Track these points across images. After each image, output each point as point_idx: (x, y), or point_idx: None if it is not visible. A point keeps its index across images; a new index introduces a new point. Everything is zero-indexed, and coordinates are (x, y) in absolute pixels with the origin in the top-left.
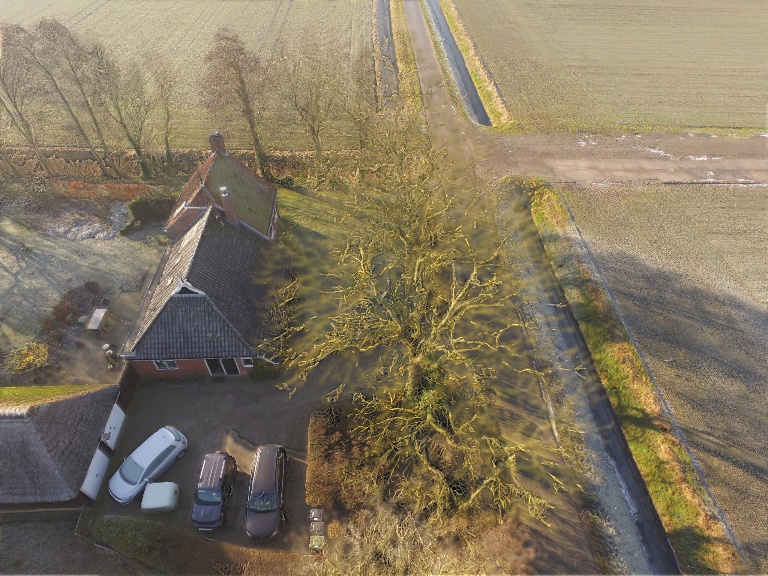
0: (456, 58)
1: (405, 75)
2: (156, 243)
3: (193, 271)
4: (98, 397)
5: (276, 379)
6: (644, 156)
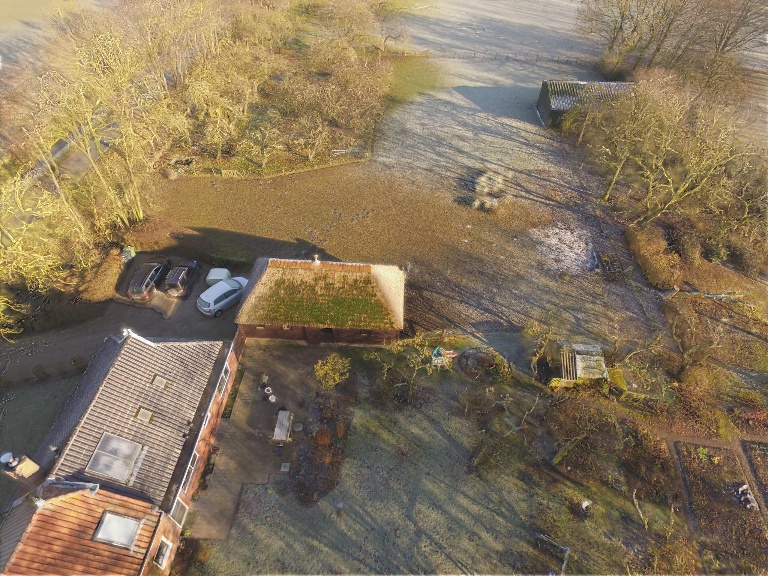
0: None
1: None
2: None
3: None
4: None
5: None
6: None
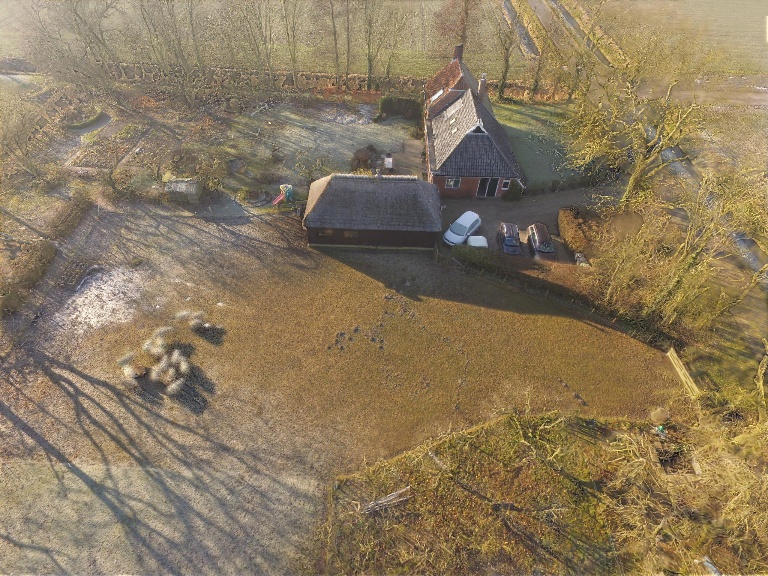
0: (571, 22)
1: (603, 3)
2: (400, 128)
3: None
4: (433, 187)
5: (519, 201)
6: (751, 91)
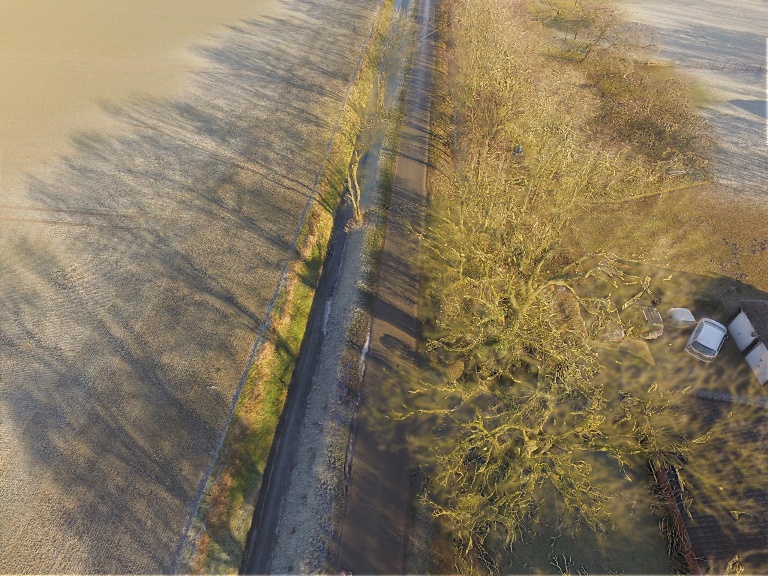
0: None
1: None
2: None
3: None
4: None
5: None
6: None
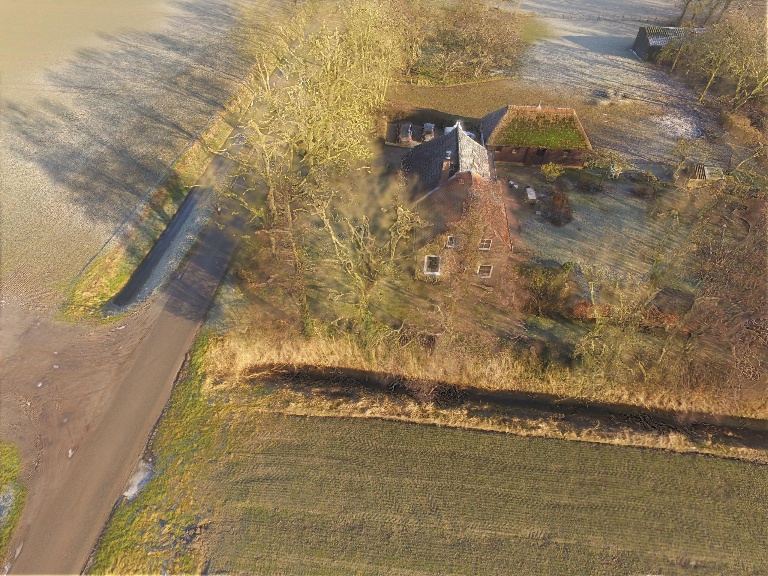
0: None
1: None
2: None
3: None
4: None
5: None
6: None
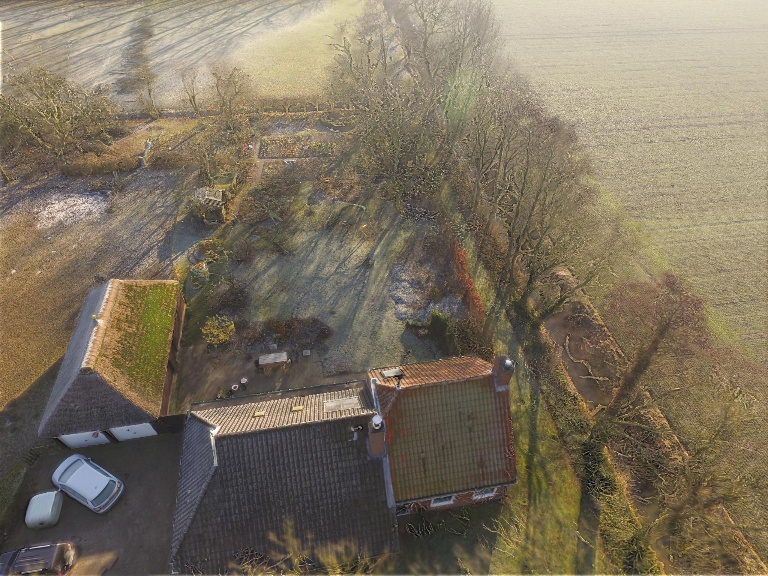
0: None
1: None
2: (402, 362)
3: (241, 438)
4: (131, 409)
5: None
6: None
